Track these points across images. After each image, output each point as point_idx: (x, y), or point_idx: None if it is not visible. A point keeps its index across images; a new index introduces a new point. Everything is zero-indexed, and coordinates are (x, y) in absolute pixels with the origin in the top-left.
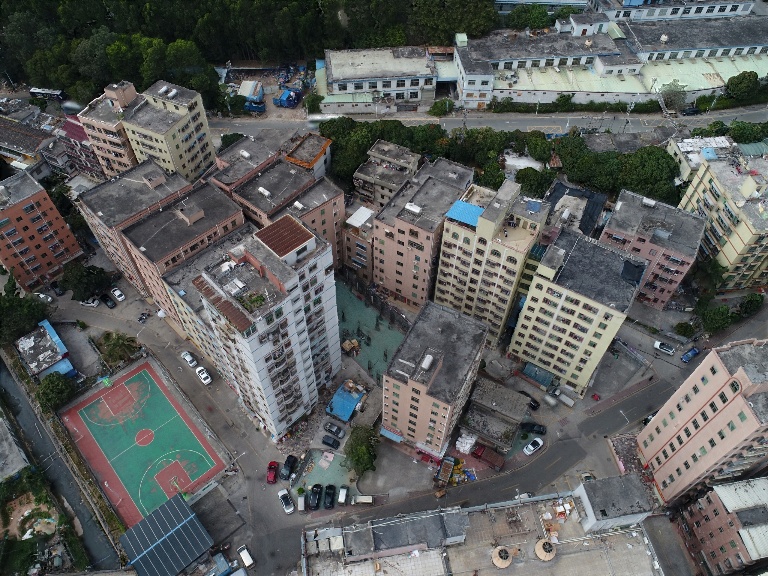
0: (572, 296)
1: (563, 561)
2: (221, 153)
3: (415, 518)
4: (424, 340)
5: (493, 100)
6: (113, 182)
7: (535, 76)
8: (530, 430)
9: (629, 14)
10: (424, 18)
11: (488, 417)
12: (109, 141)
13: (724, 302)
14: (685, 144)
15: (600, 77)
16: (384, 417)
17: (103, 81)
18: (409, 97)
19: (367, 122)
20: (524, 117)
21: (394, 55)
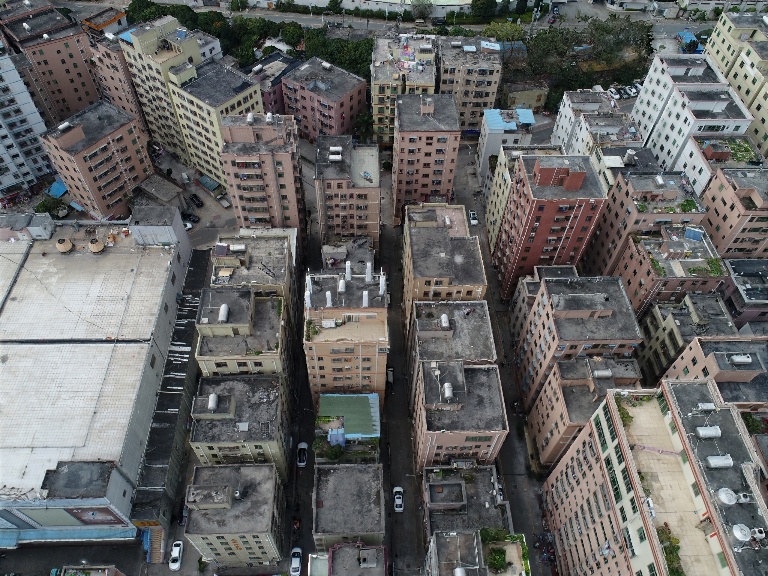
0: (189, 97)
1: (109, 256)
2: (11, 1)
3: (13, 215)
4: (84, 123)
5: (278, 1)
6: None
7: None
8: (186, 218)
9: None
10: None
11: (152, 202)
12: None
13: (388, 156)
14: None
15: None
16: (68, 188)
17: None
18: None
19: (166, 6)
20: (301, 17)
21: None
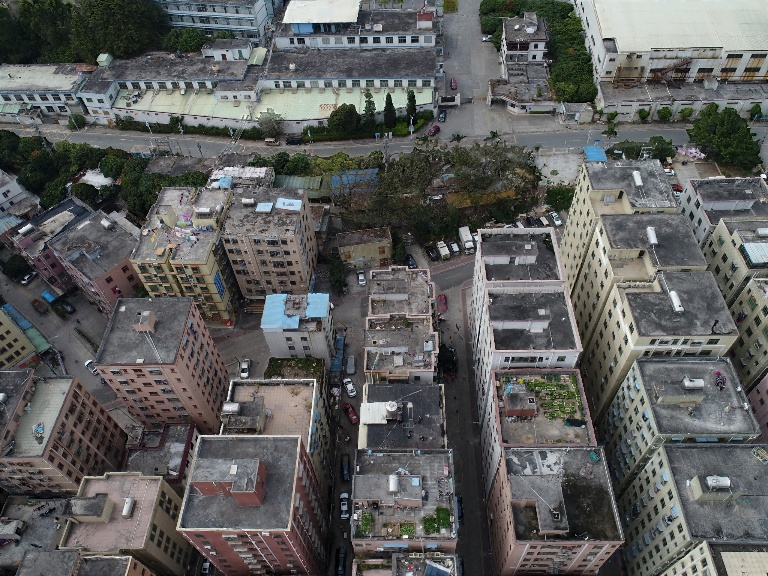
0: None
1: None
2: None
3: None
4: None
5: (116, 118)
6: None
7: (158, 97)
8: None
9: (304, 41)
10: (75, 38)
11: None
12: None
13: None
14: (221, 172)
15: (217, 102)
16: None
17: None
18: (59, 111)
19: None
20: (141, 136)
21: (55, 71)
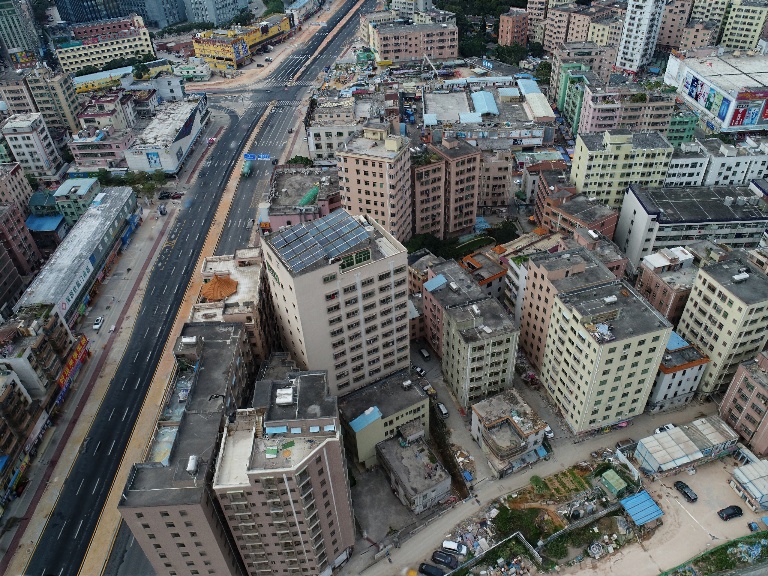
0: (747, 8)
1: None
2: None
3: None
4: None
5: None
6: (557, 7)
7: None
8: None
9: None
10: None
11: None
12: (538, 8)
13: None
14: None
15: None
16: None
17: (510, 5)
18: None
19: None
20: None
21: None
